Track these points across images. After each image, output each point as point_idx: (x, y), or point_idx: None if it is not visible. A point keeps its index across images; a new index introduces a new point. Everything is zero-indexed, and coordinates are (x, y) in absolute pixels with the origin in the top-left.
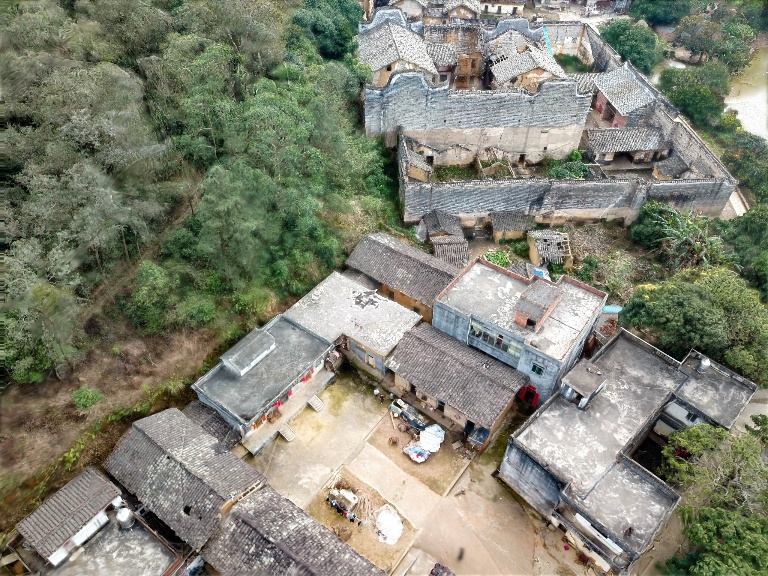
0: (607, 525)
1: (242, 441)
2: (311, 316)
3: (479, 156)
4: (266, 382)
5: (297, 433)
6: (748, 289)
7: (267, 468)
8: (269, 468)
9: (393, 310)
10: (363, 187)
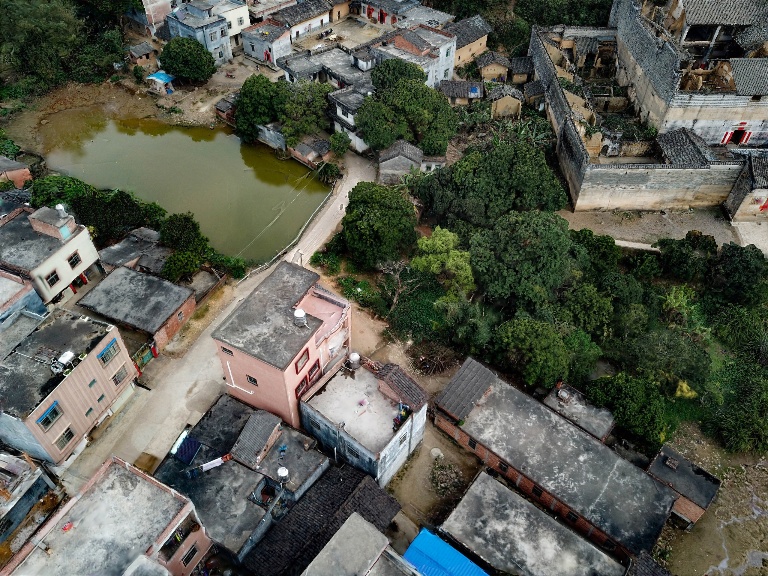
0: (292, 61)
1: (361, 15)
2: (421, 10)
3: (628, 88)
4: (379, 1)
5: (367, 30)
6: (424, 111)
7: (351, 25)
8: (351, 25)
9: None
10: None
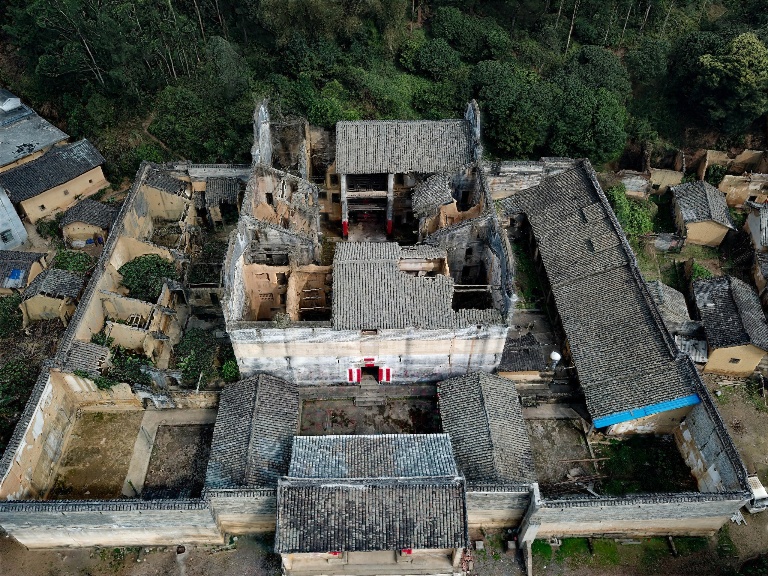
0: None
1: None
2: (27, 126)
3: None
4: None
5: None
6: None
7: None
8: None
9: (3, 159)
10: (191, 158)
